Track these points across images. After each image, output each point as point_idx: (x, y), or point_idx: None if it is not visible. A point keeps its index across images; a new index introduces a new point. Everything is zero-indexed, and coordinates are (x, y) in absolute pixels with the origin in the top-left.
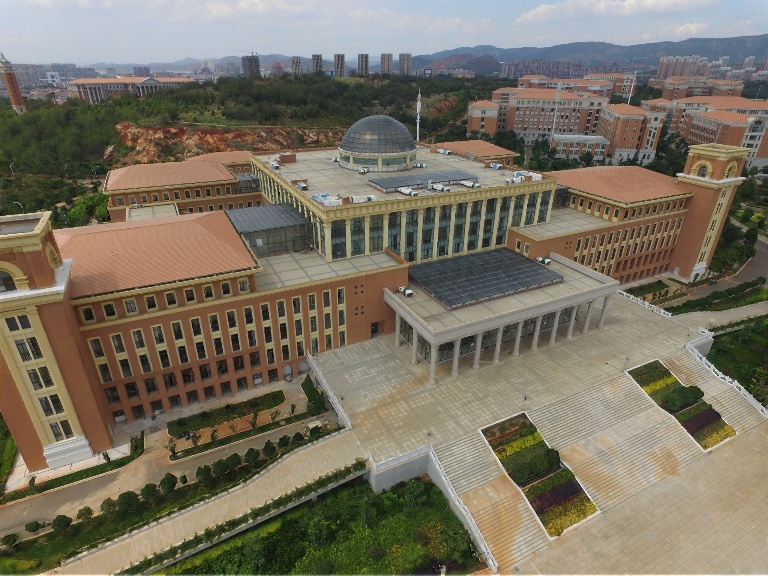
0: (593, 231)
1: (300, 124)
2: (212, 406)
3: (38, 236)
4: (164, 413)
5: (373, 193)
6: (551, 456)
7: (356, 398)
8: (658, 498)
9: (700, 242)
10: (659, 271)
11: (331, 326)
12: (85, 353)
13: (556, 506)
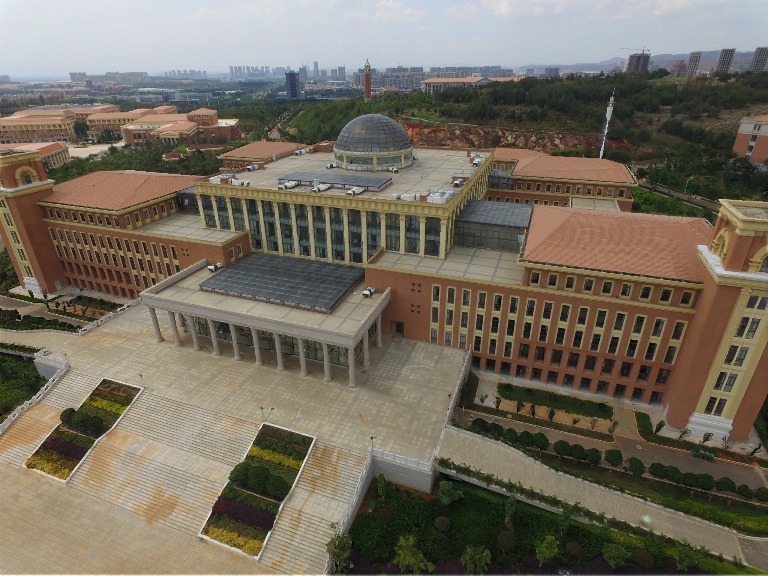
0: (457, 282)
1: (509, 125)
2: (104, 298)
3: (3, 160)
4: (88, 290)
5: (273, 182)
6: (90, 420)
7: (118, 324)
8: (104, 516)
9: (699, 375)
10: (641, 397)
11: None
12: (43, 234)
13: (58, 454)
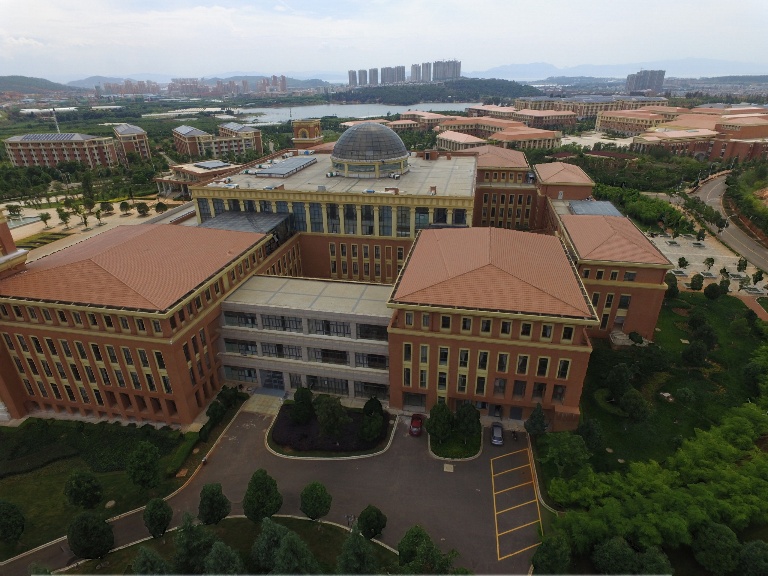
0: None
1: None
2: None
3: (295, 123)
4: None
5: None
6: None
7: None
8: None
9: None
10: None
11: None
12: None
13: None
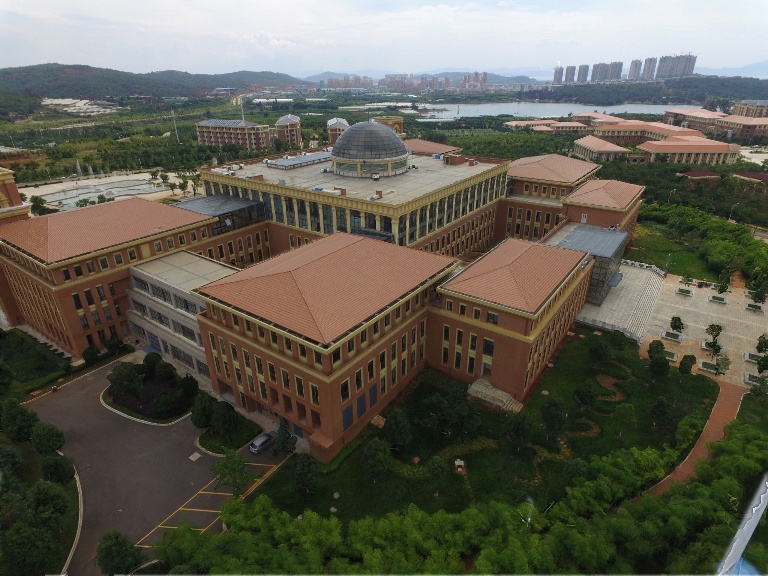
0: None
1: None
2: None
3: None
4: None
5: None
6: None
7: None
8: None
9: None
10: None
11: None
12: None
13: None
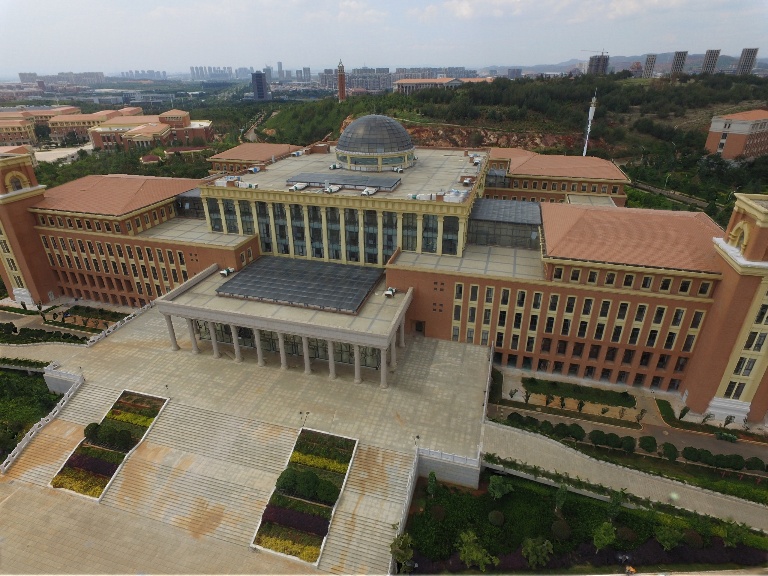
0: (481, 279)
1: (491, 125)
2: (102, 307)
3: None
4: (83, 300)
5: (280, 184)
6: (118, 434)
7: (127, 333)
8: (146, 533)
9: (720, 361)
10: (659, 385)
11: (179, 281)
12: (35, 242)
13: (85, 472)
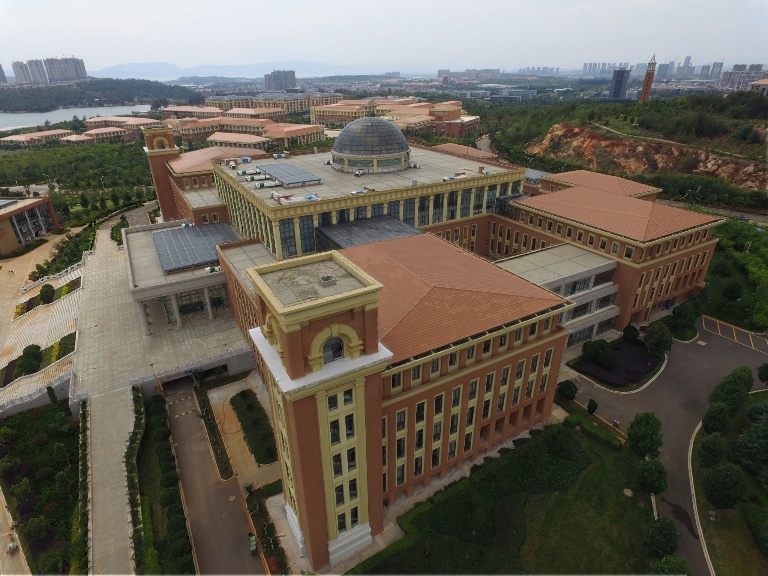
0: None
1: (728, 147)
2: None
3: (146, 131)
4: None
5: None
6: None
7: None
8: None
9: None
10: None
11: None
12: None
13: None
